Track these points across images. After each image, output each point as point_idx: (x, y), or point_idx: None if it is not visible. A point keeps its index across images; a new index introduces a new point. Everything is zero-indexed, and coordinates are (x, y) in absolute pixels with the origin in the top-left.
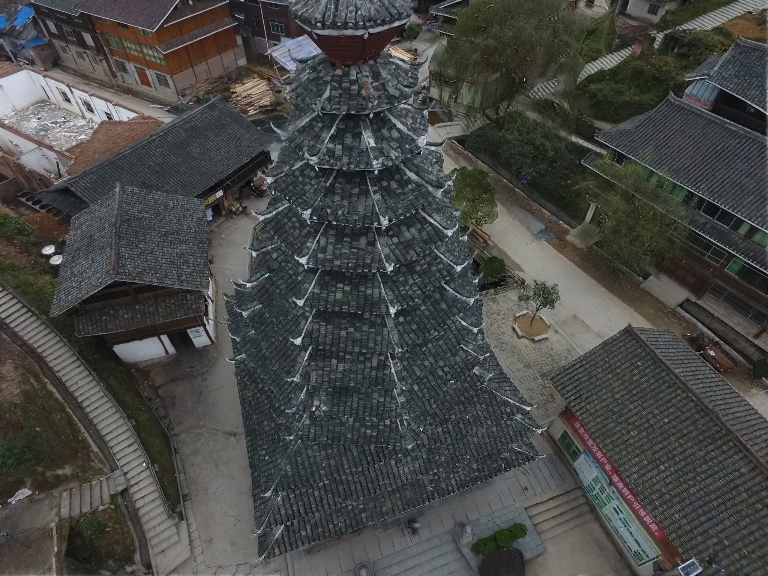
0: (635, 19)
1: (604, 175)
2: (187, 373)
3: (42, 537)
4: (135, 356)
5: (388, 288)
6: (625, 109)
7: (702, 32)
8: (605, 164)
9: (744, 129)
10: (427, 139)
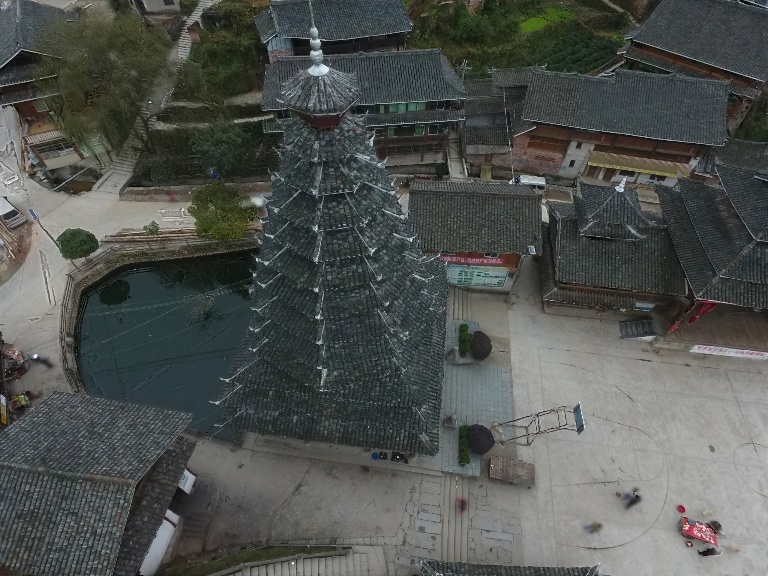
0: (160, 14)
1: None
2: (211, 512)
3: None
4: (156, 560)
5: (400, 232)
6: (229, 83)
7: (225, 5)
8: None
9: (334, 56)
10: (104, 203)
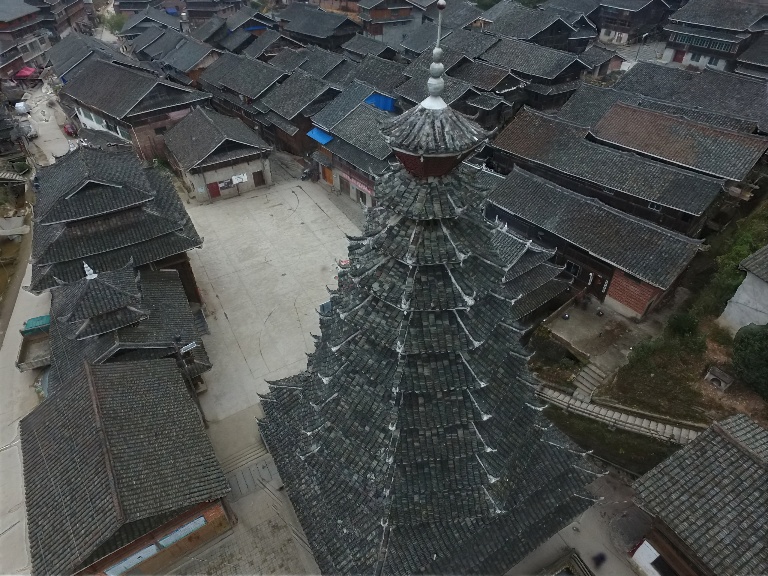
0: None
1: None
2: None
3: (590, 352)
4: None
5: None
6: None
7: None
8: None
9: None
10: None
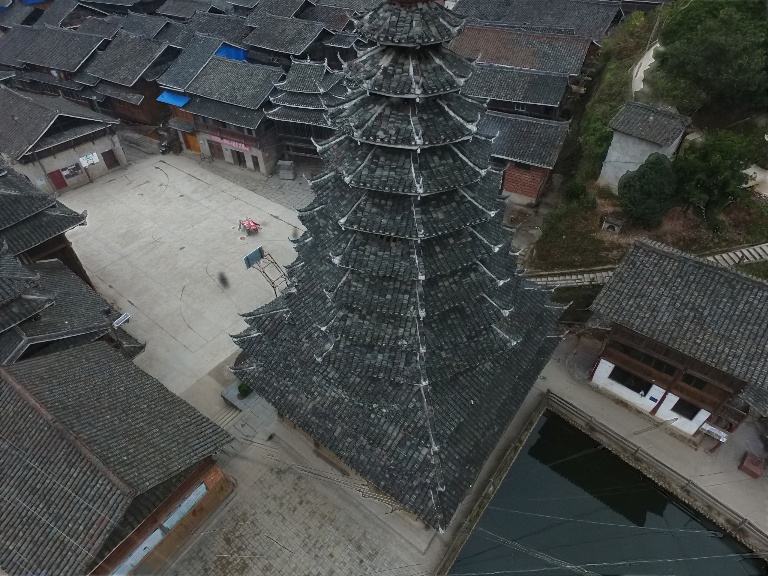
0: None
1: None
2: None
3: None
4: None
5: None
6: None
7: None
8: None
9: None
10: None
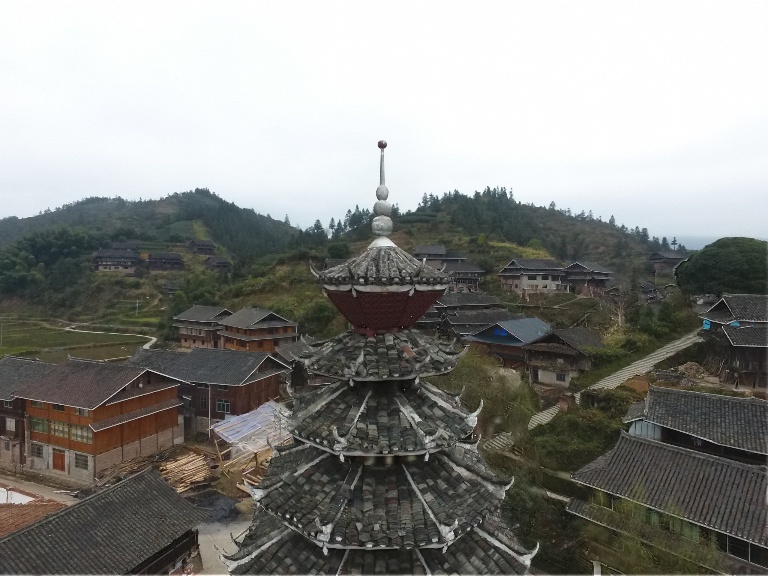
0: (548, 385)
1: (598, 522)
2: None
3: None
4: None
5: None
6: (577, 457)
7: (611, 389)
8: (593, 509)
9: (712, 456)
10: None
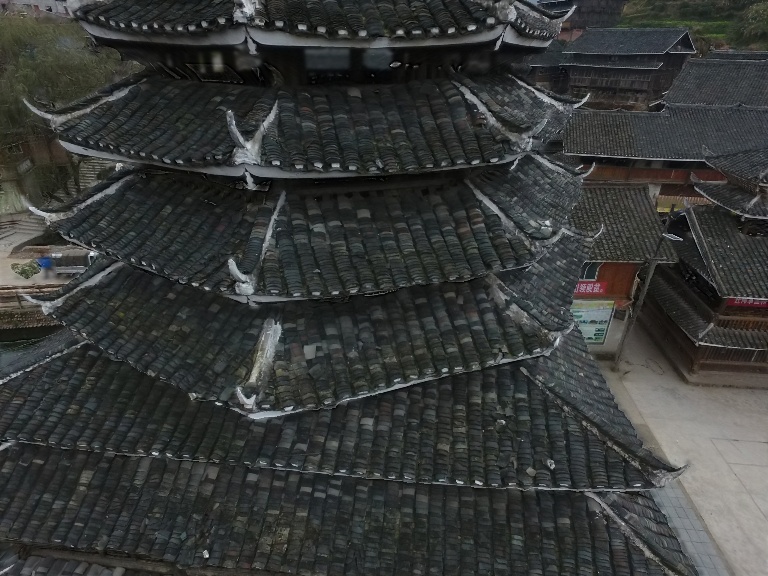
0: None
1: None
2: None
3: None
4: None
5: None
6: None
7: None
8: None
9: None
10: None
